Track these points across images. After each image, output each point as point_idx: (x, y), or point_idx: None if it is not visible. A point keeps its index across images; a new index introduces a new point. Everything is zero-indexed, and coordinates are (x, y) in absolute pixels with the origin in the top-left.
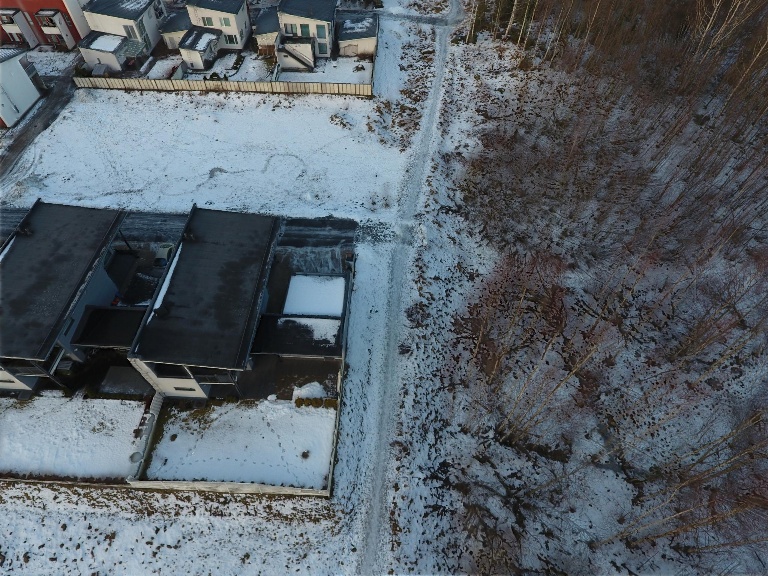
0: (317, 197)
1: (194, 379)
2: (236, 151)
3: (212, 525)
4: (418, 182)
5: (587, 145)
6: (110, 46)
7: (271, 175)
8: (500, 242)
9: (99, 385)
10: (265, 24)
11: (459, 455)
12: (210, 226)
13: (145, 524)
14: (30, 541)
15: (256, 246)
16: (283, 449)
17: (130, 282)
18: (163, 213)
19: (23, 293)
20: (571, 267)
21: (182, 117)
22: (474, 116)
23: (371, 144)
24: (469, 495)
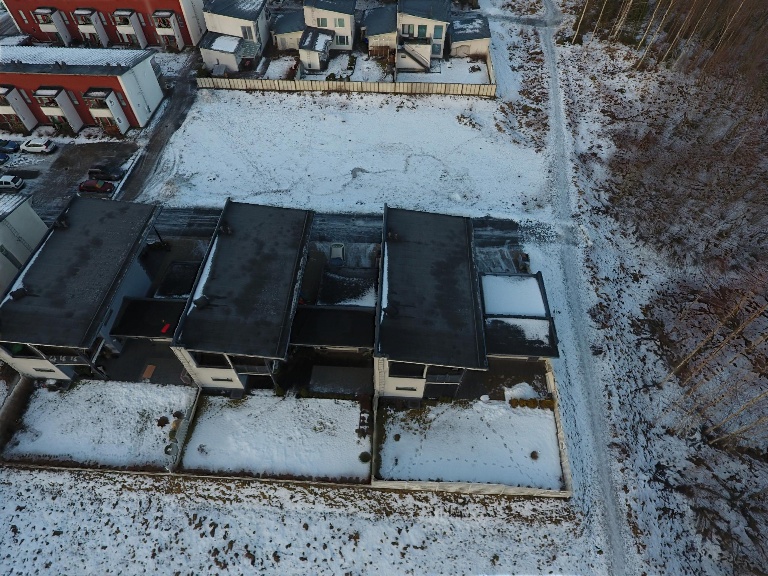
0: (466, 197)
1: (425, 379)
2: (372, 151)
3: (453, 526)
4: (564, 183)
5: (722, 146)
6: (230, 47)
7: (414, 175)
8: (656, 243)
9: (308, 384)
10: (375, 25)
11: (672, 457)
12: (407, 226)
13: (386, 524)
14: (276, 540)
15: (457, 246)
16: (510, 450)
17: (322, 281)
18: (319, 213)
19: (243, 292)
20: (735, 268)
21: (309, 117)
22: (600, 117)
23: (505, 144)
24: (695, 498)
